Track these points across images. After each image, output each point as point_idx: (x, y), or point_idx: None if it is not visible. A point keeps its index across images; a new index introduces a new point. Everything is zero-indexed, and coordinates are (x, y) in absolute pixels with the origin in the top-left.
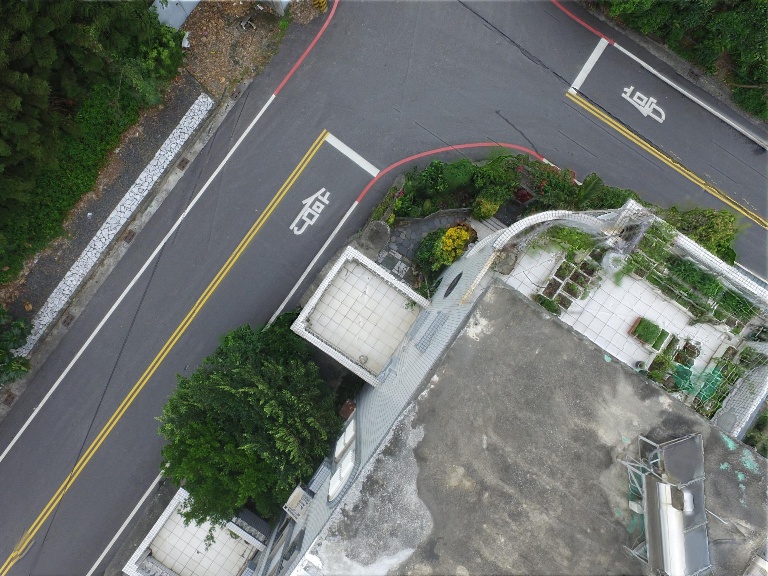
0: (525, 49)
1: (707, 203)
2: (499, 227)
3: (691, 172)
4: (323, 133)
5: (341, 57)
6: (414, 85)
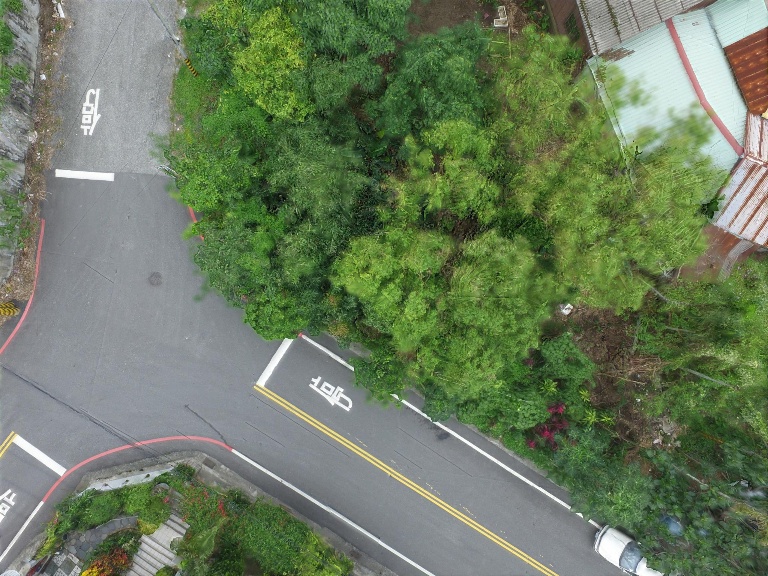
0: (214, 344)
1: (392, 488)
2: (183, 522)
3: (377, 458)
4: (10, 436)
5: (31, 359)
6: (102, 384)
